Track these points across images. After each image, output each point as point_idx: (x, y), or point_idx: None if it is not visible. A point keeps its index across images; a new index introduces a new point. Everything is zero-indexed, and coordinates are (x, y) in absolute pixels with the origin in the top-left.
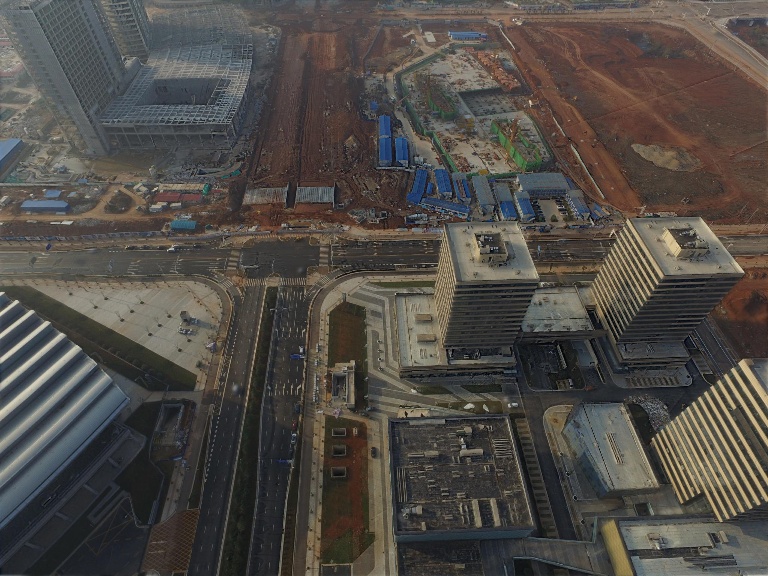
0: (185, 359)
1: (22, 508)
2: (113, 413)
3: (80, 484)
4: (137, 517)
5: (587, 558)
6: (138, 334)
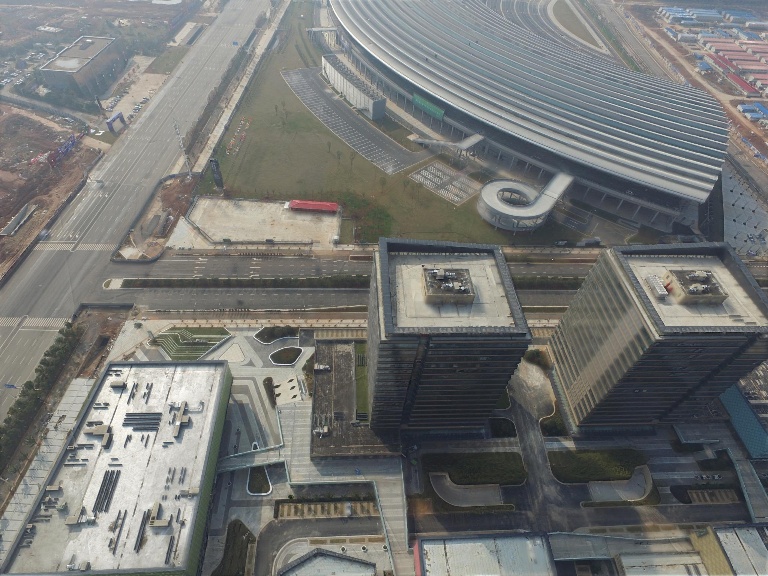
0: (731, 242)
1: (629, 179)
2: (692, 197)
3: (642, 203)
4: (629, 238)
5: (763, 515)
6: (730, 215)
